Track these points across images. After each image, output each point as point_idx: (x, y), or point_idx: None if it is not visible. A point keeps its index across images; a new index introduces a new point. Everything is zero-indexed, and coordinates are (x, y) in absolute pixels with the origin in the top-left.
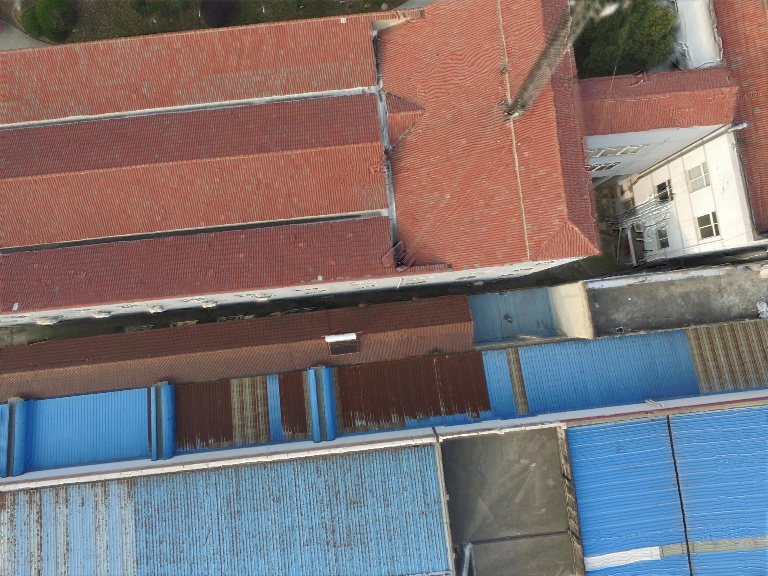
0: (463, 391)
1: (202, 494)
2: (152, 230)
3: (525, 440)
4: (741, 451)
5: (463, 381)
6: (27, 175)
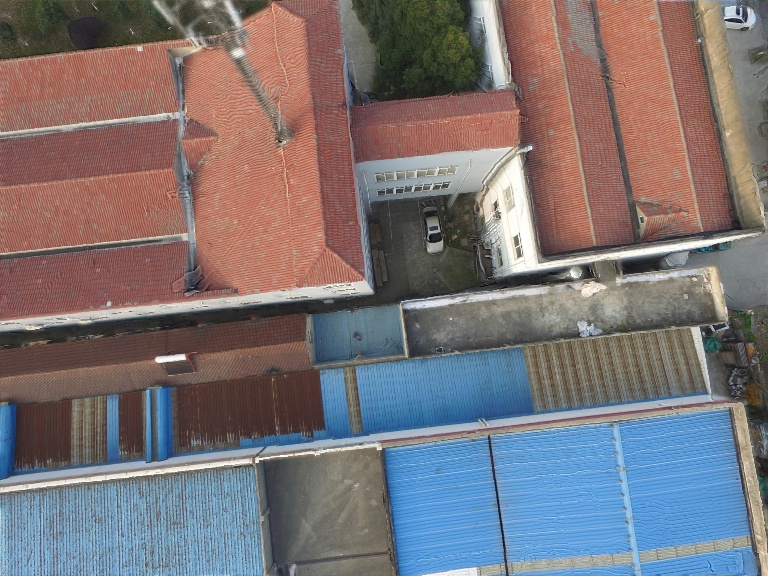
0: (299, 410)
1: (26, 515)
2: None
3: (349, 460)
4: (561, 471)
5: (299, 400)
6: None
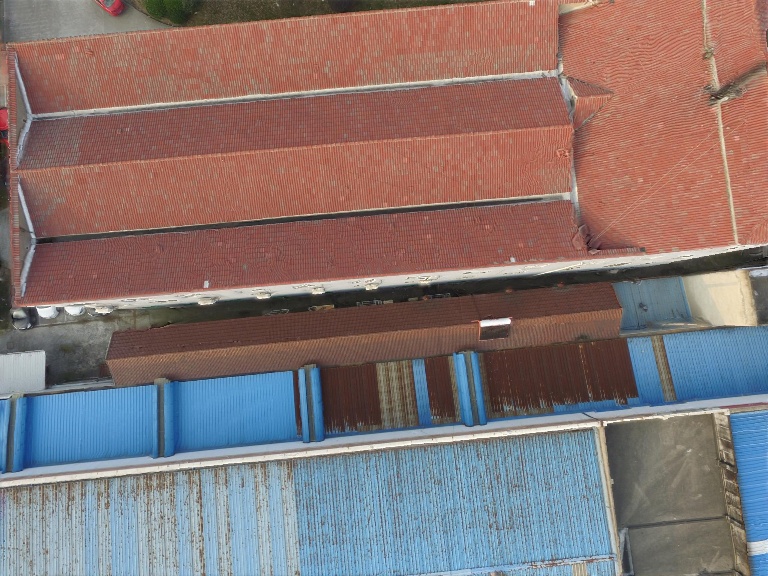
0: (610, 378)
1: (363, 476)
2: (334, 210)
3: (681, 426)
4: None
5: (609, 368)
6: (216, 152)
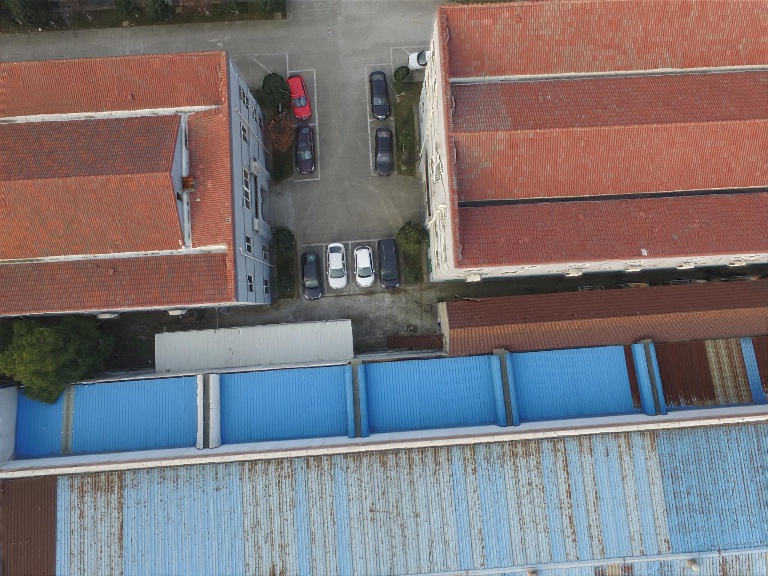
0: None
1: (724, 448)
2: (747, 185)
3: None
4: None
5: None
6: (651, 123)
